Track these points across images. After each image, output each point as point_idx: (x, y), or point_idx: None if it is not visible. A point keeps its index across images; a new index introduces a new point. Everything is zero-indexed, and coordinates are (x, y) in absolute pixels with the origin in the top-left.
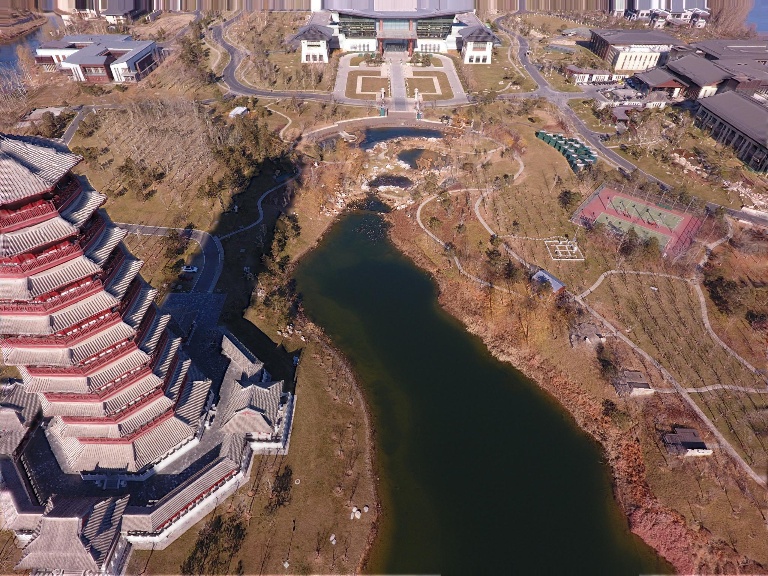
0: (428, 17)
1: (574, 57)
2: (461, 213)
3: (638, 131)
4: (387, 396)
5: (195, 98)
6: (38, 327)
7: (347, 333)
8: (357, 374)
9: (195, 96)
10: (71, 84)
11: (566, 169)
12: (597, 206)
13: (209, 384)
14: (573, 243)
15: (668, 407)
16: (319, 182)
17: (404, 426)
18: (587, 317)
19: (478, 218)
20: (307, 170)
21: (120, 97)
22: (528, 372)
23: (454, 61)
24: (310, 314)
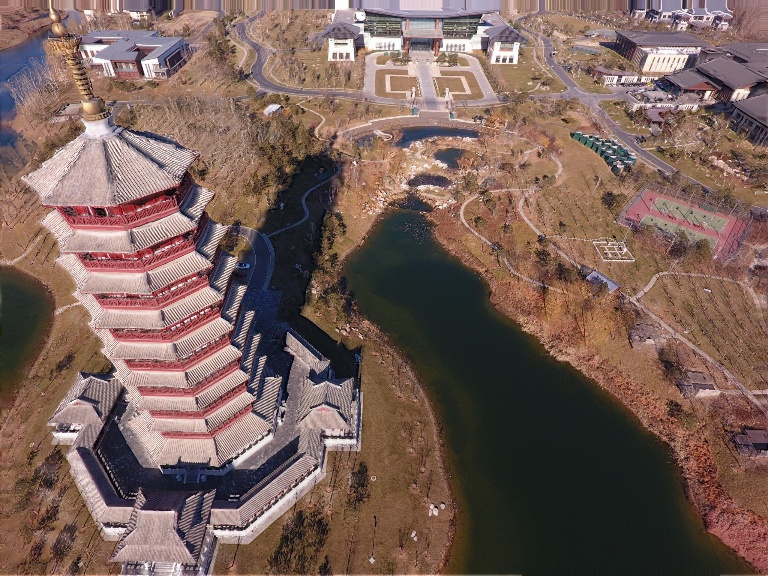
0: (455, 17)
1: (600, 58)
2: (506, 213)
3: (673, 133)
4: (449, 394)
5: (227, 95)
6: (149, 321)
7: (402, 331)
8: (418, 372)
9: (226, 93)
10: (102, 79)
11: (608, 170)
12: (641, 208)
13: (280, 380)
14: (622, 244)
15: (735, 408)
16: (360, 180)
17: (469, 424)
18: (646, 318)
19: (523, 218)
20: (346, 168)
21: (155, 93)
22: (588, 372)
23: (480, 61)
24: (364, 312)
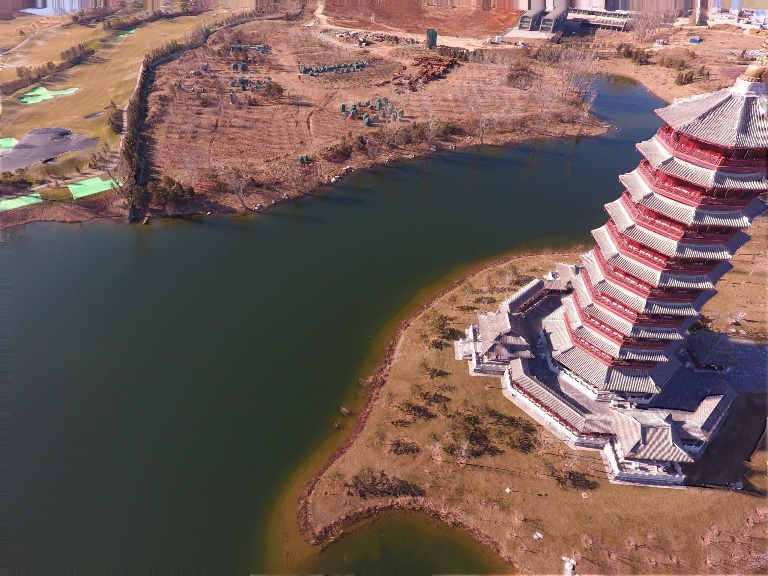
0: None
1: None
2: None
3: None
4: None
5: None
6: (623, 225)
7: None
8: None
9: None
10: None
11: None
12: None
13: (655, 391)
14: None
15: None
16: None
17: None
18: None
19: None
20: None
21: None
22: None
23: None
24: None
